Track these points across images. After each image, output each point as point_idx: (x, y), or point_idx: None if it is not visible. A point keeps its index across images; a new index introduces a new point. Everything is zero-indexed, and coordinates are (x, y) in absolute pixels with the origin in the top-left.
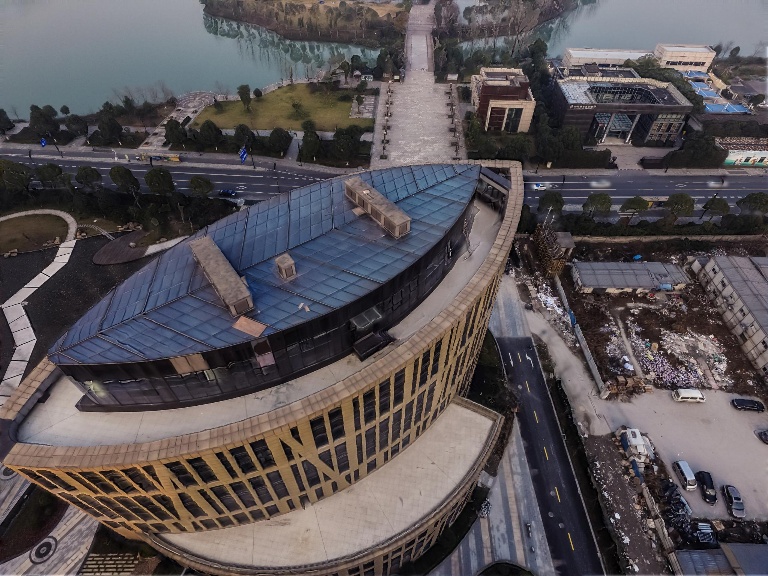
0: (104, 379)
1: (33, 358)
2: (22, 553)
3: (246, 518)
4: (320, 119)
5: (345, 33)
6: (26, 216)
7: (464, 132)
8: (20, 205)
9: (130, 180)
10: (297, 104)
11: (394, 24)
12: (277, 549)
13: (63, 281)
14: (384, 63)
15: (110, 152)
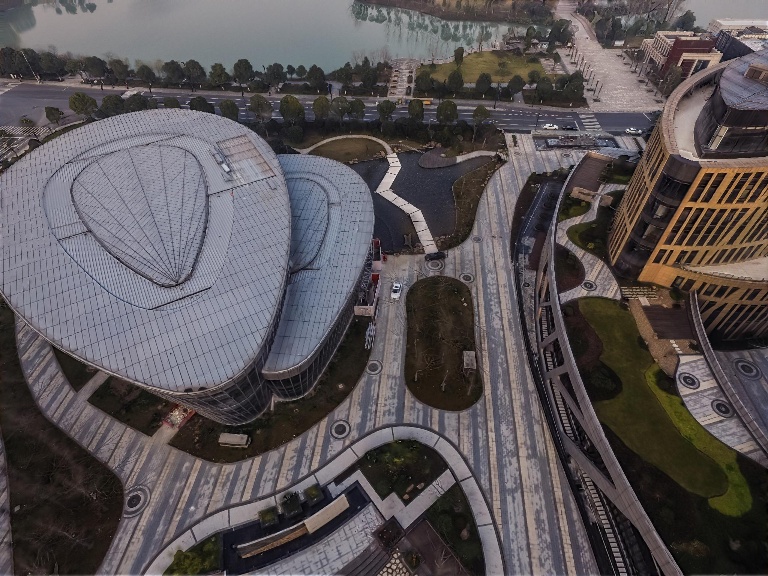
0: (750, 125)
1: (426, 221)
2: (576, 286)
3: (737, 257)
4: (523, 75)
5: (497, 13)
6: (344, 139)
7: (654, 82)
8: (336, 131)
9: (422, 111)
10: (503, 63)
11: (546, 3)
12: (763, 273)
13: (407, 178)
14: (559, 32)
15: (367, 99)
